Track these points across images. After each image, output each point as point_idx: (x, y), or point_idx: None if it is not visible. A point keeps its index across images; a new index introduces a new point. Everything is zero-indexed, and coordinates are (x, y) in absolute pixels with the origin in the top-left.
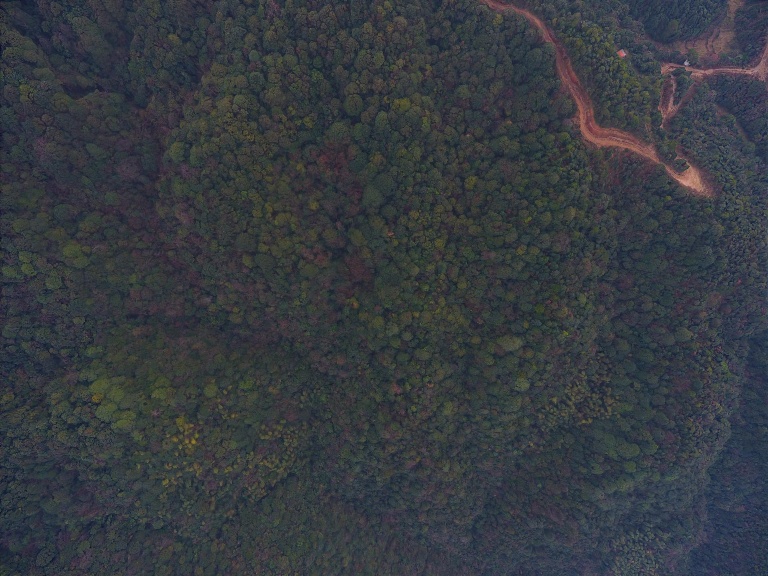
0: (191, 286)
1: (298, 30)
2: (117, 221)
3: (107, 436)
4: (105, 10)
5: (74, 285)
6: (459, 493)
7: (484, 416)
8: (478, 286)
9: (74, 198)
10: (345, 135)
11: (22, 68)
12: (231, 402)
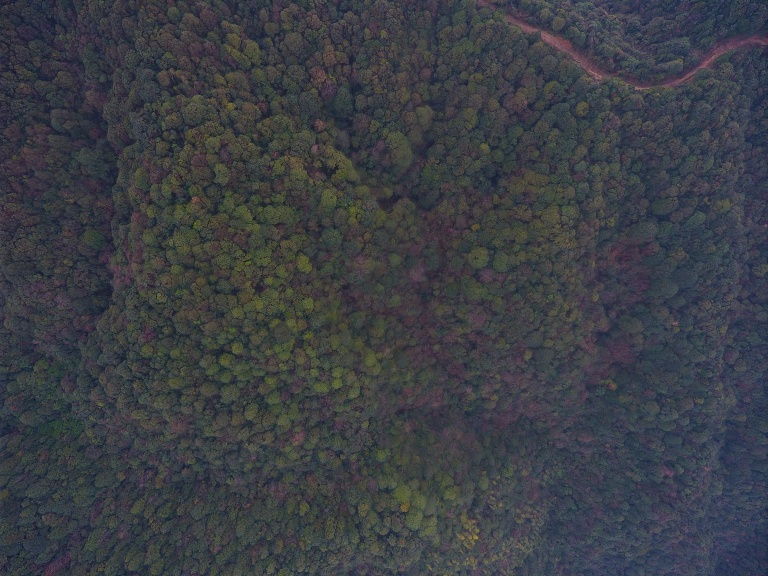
0: (450, 376)
1: (628, 139)
2: (395, 321)
3: (417, 545)
4: (418, 123)
5: (370, 393)
6: (706, 564)
7: (743, 490)
8: (760, 369)
9: (362, 304)
10: (654, 234)
11: (350, 190)
12: (501, 492)
